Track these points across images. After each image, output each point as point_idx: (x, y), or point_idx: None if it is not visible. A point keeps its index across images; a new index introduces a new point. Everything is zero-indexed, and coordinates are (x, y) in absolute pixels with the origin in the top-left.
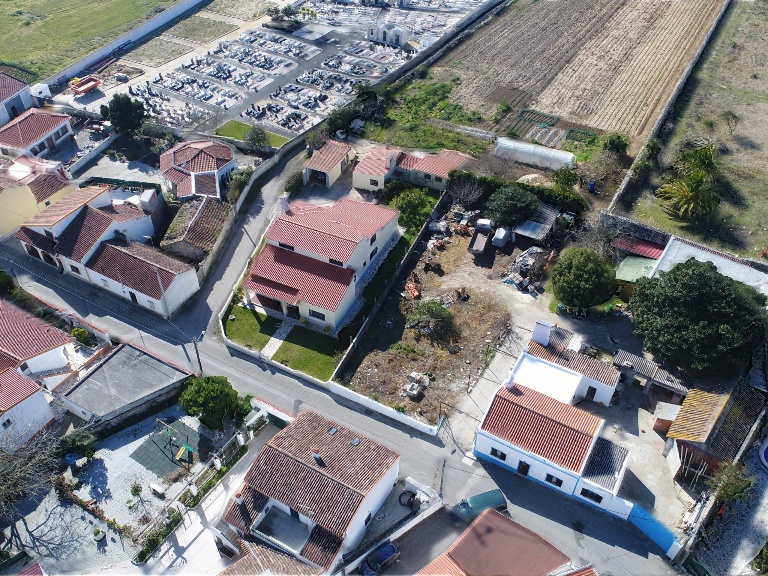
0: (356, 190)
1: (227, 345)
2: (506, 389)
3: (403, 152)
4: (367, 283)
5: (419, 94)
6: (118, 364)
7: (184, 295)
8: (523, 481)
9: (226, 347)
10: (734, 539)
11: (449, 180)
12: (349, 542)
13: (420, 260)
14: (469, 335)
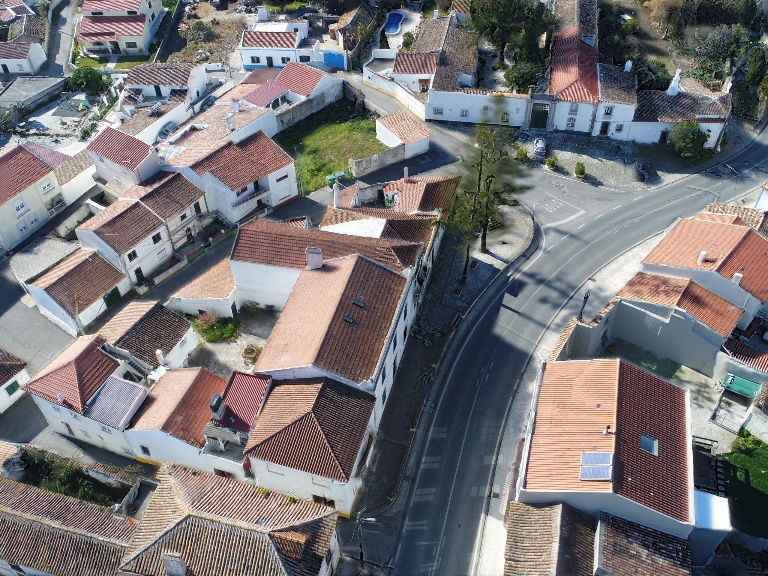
0: None
1: None
2: None
3: None
4: (155, 32)
5: None
6: (19, 84)
7: (39, 61)
8: None
9: None
10: None
11: None
12: (192, 99)
13: (183, 16)
14: (225, 35)
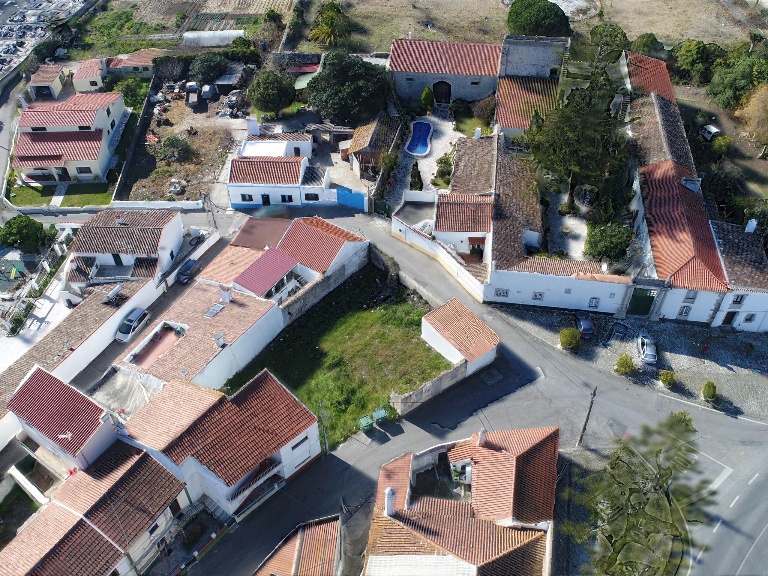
0: (80, 93)
1: (18, 210)
2: (238, 158)
3: (109, 58)
4: (116, 146)
5: (106, 22)
6: None
7: None
8: (269, 209)
9: (18, 211)
10: (400, 191)
11: (154, 66)
12: (163, 266)
13: (152, 122)
14: (205, 152)
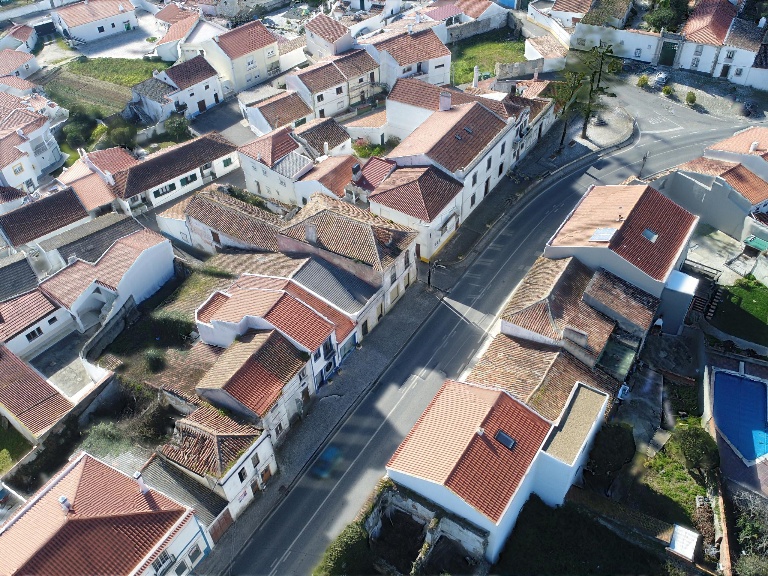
0: None
1: None
2: None
3: None
4: None
5: None
6: None
7: None
8: None
9: None
10: None
11: None
12: (386, 14)
13: None
14: None
